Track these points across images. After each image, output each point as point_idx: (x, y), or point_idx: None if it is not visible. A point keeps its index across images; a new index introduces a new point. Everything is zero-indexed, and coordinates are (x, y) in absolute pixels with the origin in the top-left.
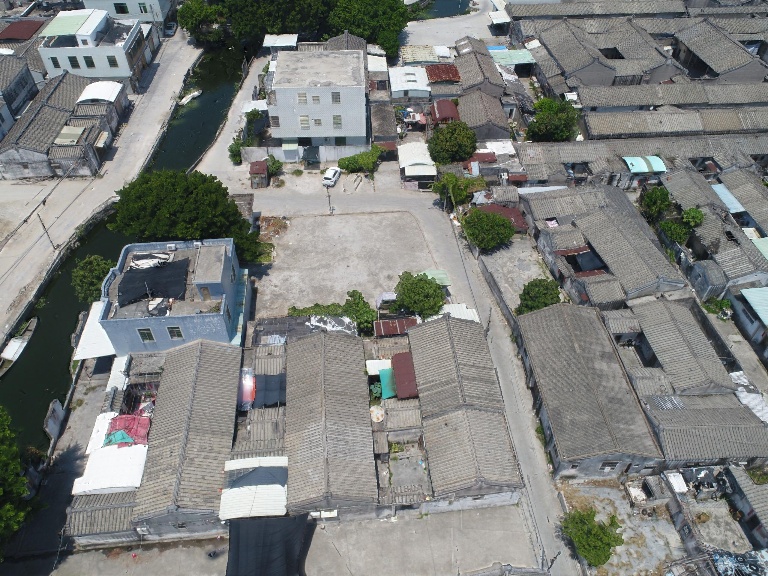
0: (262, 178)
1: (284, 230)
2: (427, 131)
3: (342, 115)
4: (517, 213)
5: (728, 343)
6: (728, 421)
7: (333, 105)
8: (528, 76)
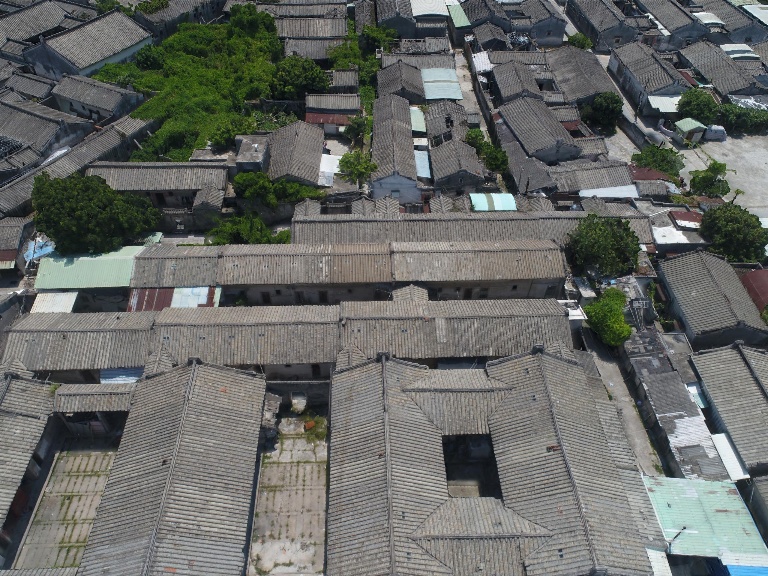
0: None
1: None
2: None
3: None
4: None
5: (468, 110)
6: (508, 55)
7: None
8: None
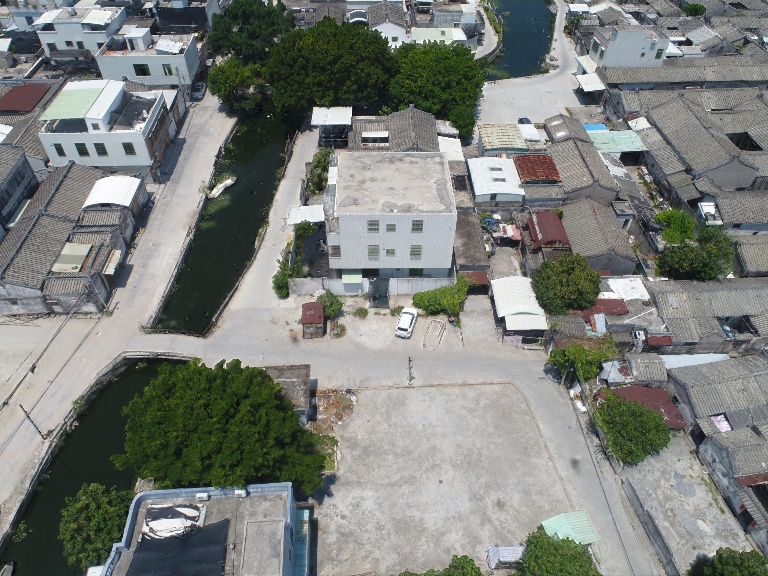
0: (317, 328)
1: (349, 413)
2: (526, 255)
3: (423, 245)
4: (665, 398)
5: None
6: None
7: (412, 234)
8: (634, 164)
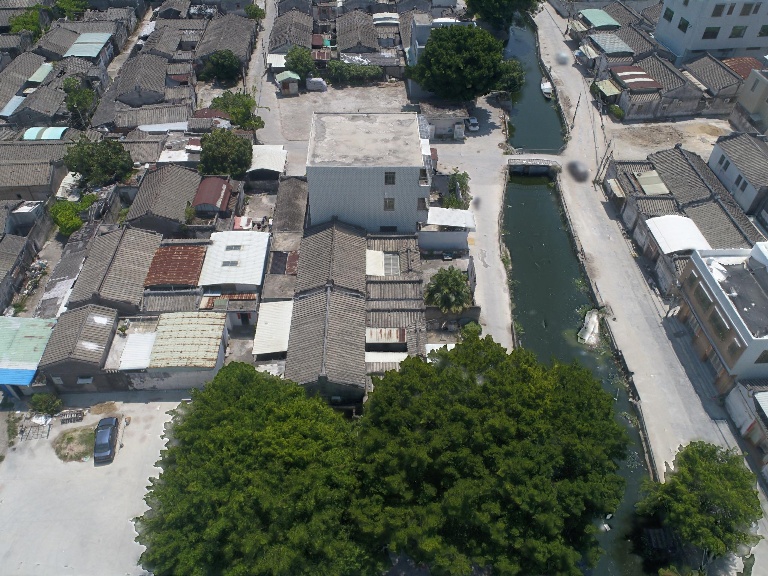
0: None
1: None
2: None
3: None
4: None
5: None
6: (171, 22)
7: None
8: None
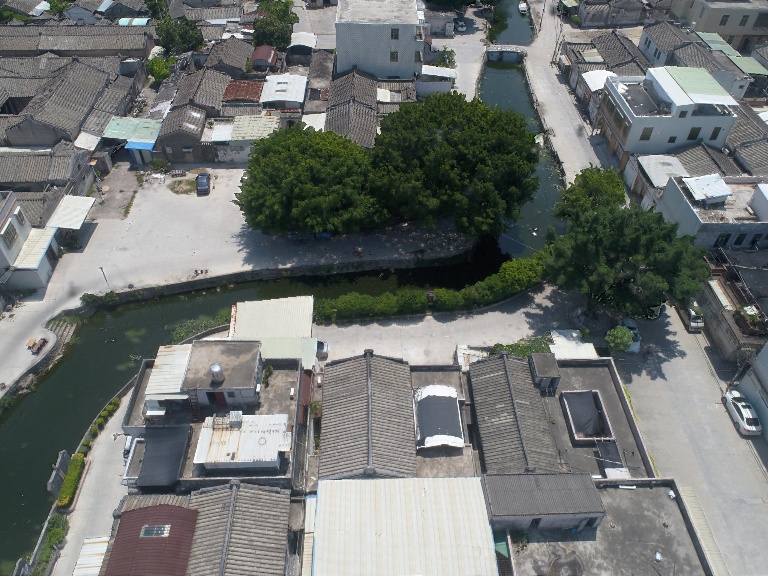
0: None
1: None
2: None
3: None
4: None
5: None
6: None
7: None
8: None
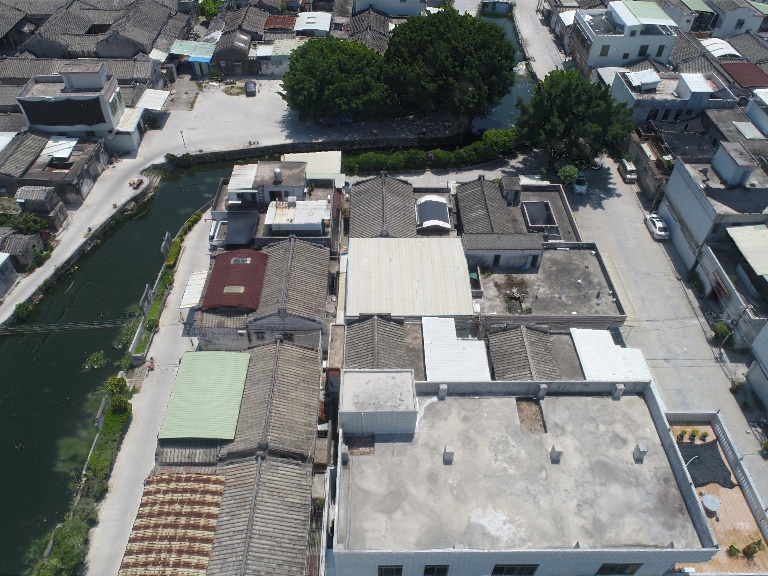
0: None
1: None
2: None
3: None
4: None
5: None
6: None
7: None
8: None
